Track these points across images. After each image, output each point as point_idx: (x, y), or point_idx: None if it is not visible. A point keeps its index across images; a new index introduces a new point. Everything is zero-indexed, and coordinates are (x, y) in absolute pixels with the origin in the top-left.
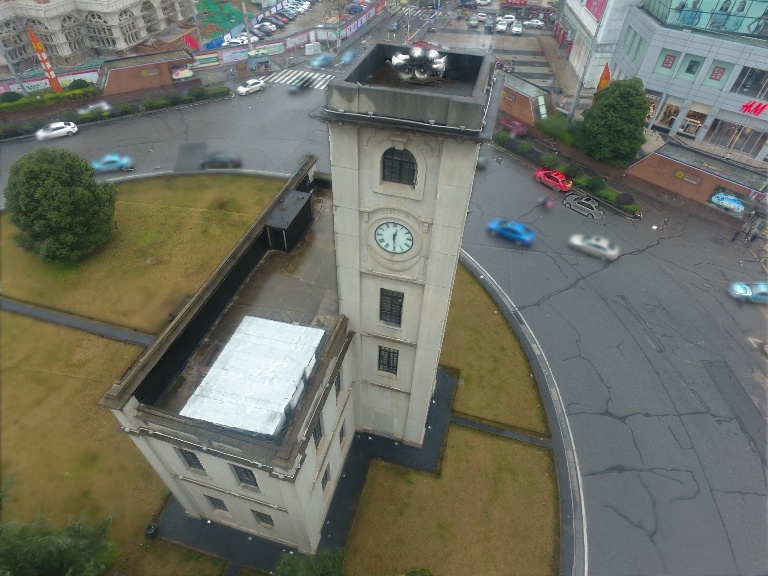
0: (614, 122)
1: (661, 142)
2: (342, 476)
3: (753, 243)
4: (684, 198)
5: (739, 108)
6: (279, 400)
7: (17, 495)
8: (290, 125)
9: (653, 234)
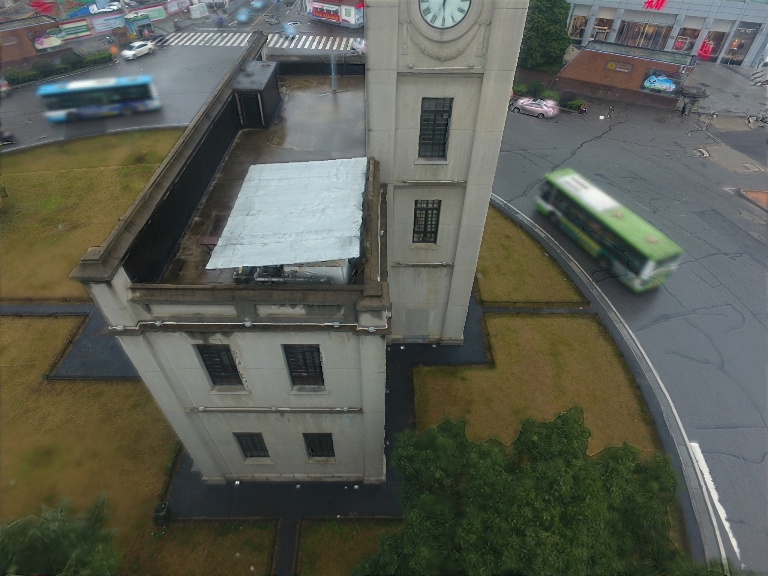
0: (541, 23)
1: (577, 51)
2: (386, 392)
3: (690, 117)
4: (618, 89)
5: (642, 5)
6: (346, 225)
7: None
8: (196, 80)
9: (603, 123)
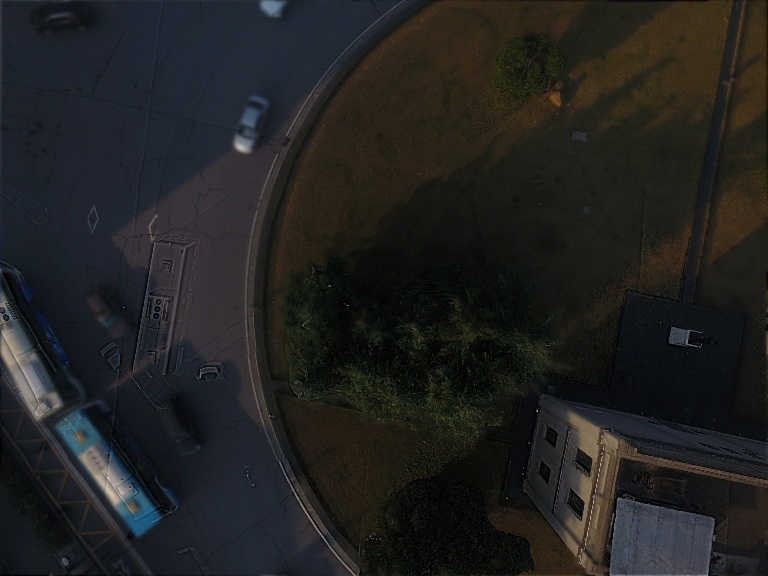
0: None
1: None
2: None
3: None
4: None
5: None
6: (637, 572)
7: (543, 268)
8: None
9: None
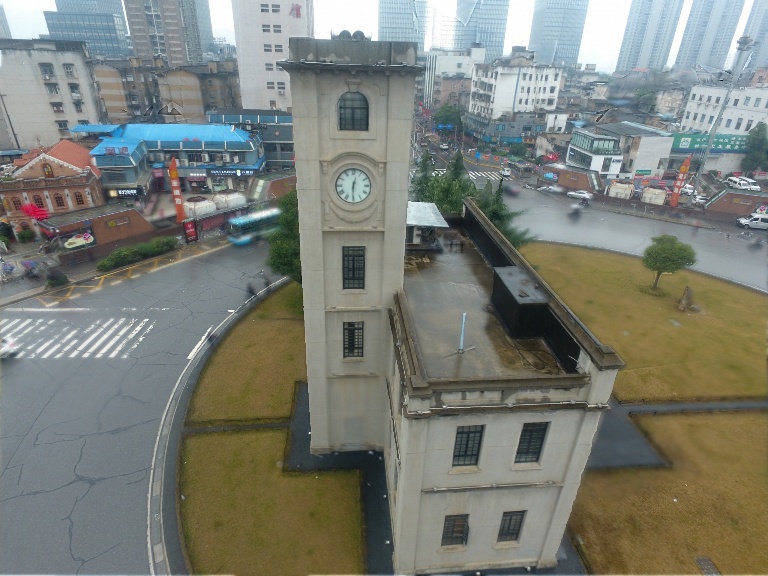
0: None
1: None
2: None
3: None
4: None
5: None
6: None
7: None
8: None
9: None
